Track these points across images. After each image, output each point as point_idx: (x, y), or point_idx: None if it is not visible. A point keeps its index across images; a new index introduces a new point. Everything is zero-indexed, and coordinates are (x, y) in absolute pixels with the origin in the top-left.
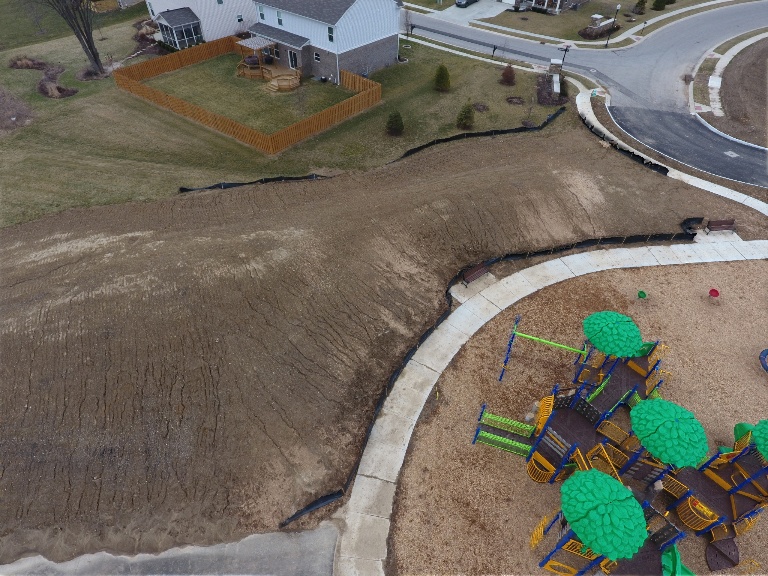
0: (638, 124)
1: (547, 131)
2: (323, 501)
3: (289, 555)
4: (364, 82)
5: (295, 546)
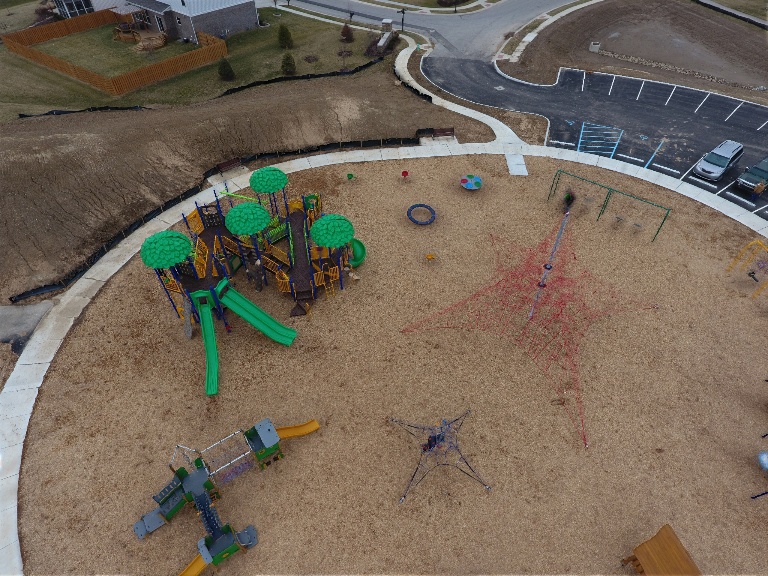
0: (440, 69)
1: (357, 75)
2: (47, 289)
3: (13, 316)
4: (213, 40)
5: (19, 312)
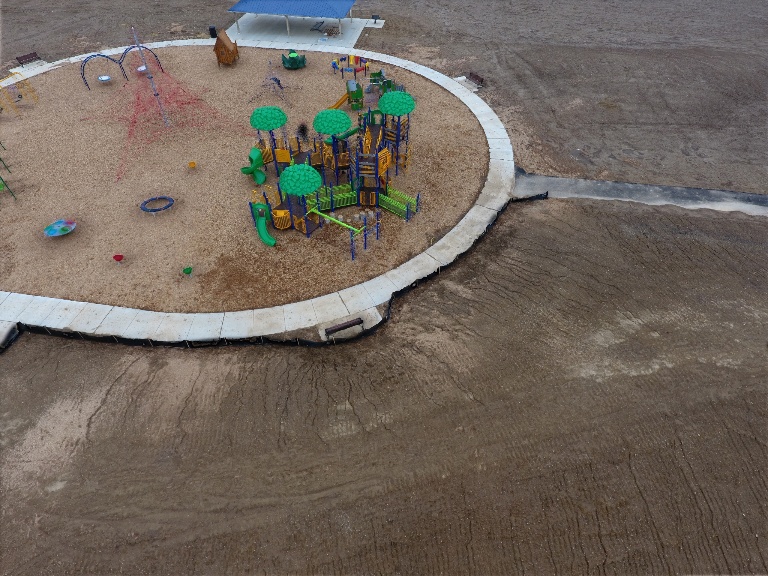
0: None
1: None
2: (523, 200)
3: (540, 189)
4: None
5: (537, 192)
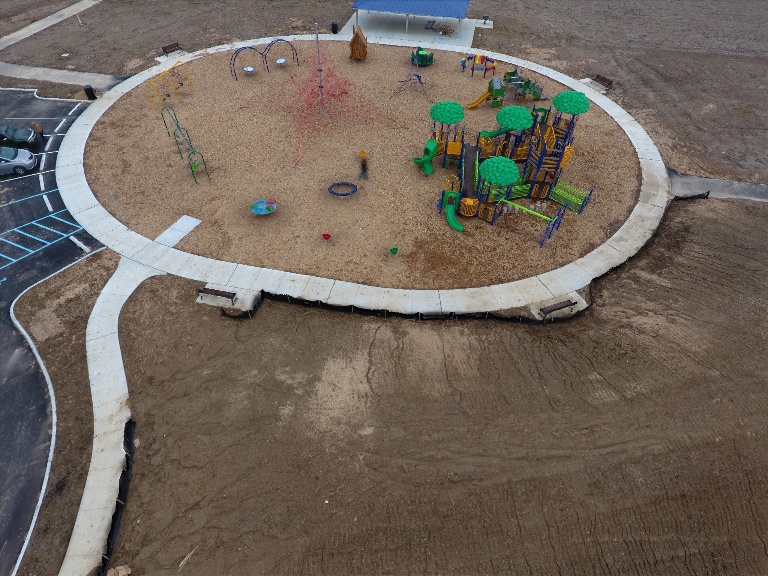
0: None
1: None
2: (685, 199)
3: (697, 189)
4: None
5: (695, 191)
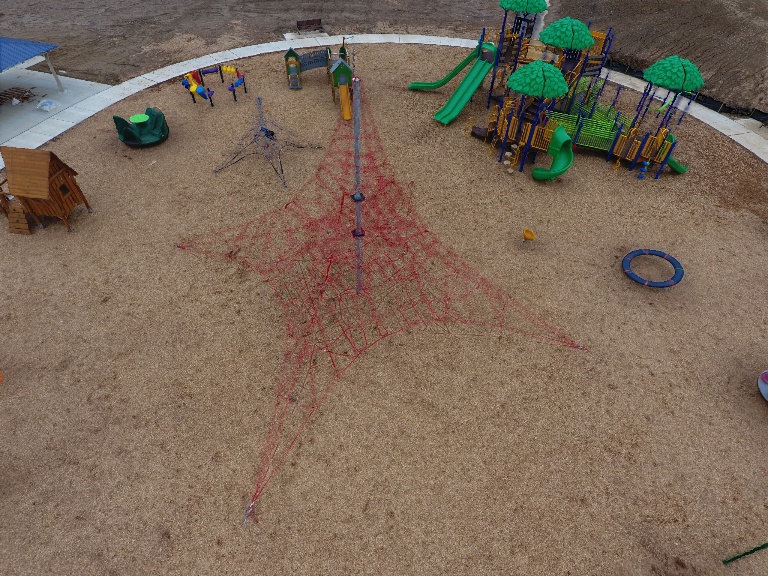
0: None
1: None
2: None
3: None
4: None
5: None
